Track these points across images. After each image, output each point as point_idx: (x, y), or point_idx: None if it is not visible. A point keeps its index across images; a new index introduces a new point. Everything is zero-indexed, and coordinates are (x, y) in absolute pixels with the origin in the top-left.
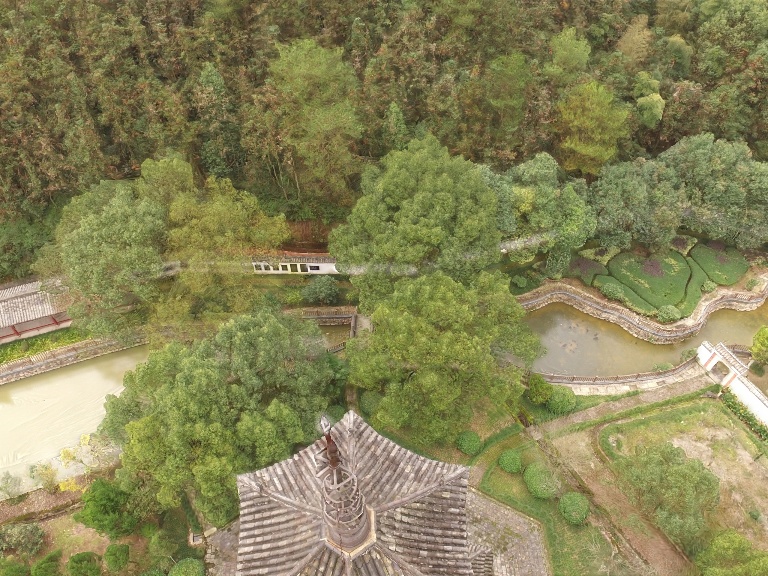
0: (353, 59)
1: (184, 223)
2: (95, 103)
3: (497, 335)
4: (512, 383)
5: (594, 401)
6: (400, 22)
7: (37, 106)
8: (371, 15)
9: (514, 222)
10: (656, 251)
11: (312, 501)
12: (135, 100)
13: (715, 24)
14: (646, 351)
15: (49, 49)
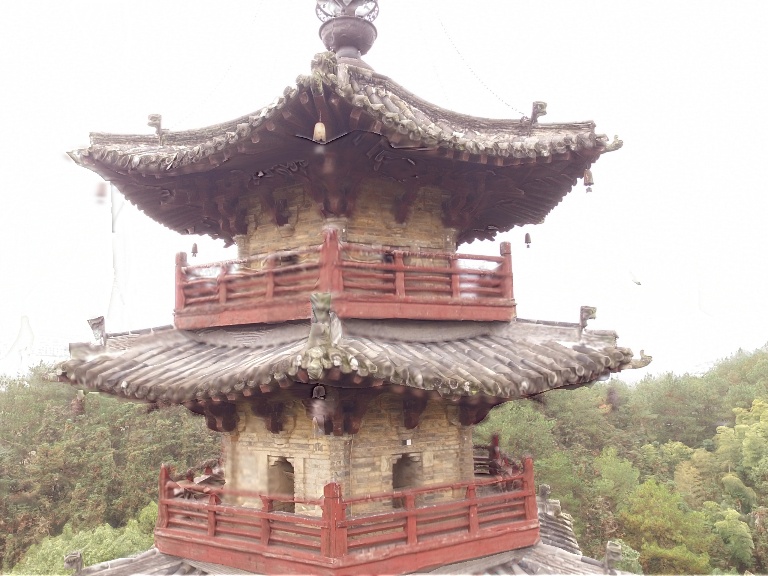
0: None
1: None
2: None
3: None
4: None
5: None
6: None
7: (55, 497)
8: None
9: None
10: None
11: None
12: None
13: (764, 465)
14: None
15: (100, 430)
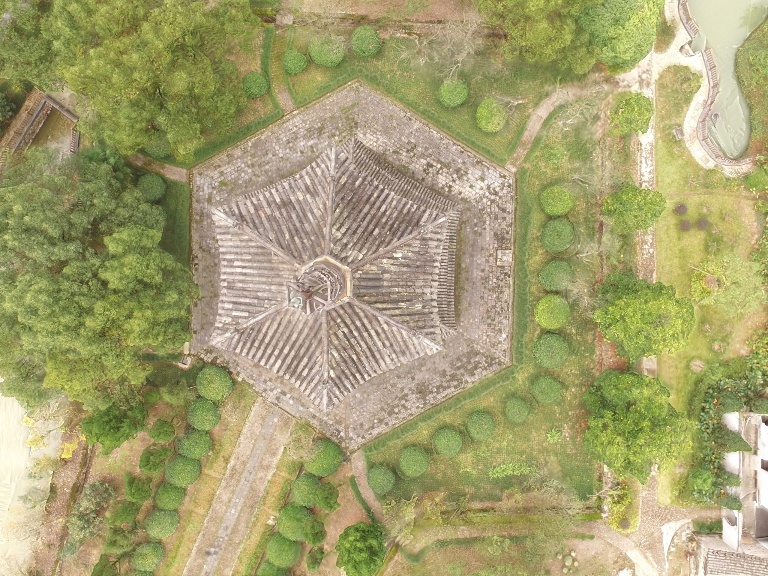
0: None
1: None
2: None
3: None
4: (234, 4)
5: None
6: None
7: None
8: None
9: None
10: None
11: (279, 297)
12: None
13: None
14: None
15: None
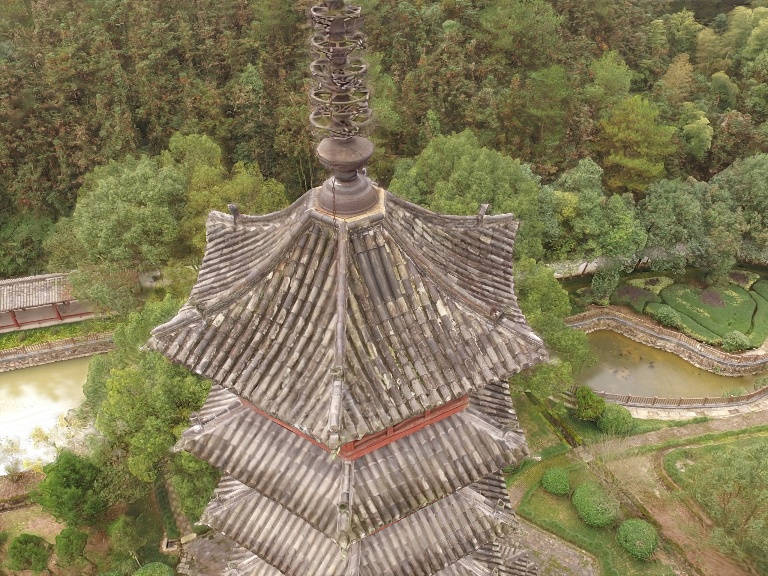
0: (392, 73)
1: (205, 190)
2: (136, 102)
3: (539, 318)
4: (558, 372)
5: (654, 425)
6: (440, 43)
7: (80, 101)
8: (412, 36)
9: (556, 226)
10: (714, 283)
11: None
12: (174, 97)
13: (759, 62)
14: (712, 382)
15: (99, 39)
